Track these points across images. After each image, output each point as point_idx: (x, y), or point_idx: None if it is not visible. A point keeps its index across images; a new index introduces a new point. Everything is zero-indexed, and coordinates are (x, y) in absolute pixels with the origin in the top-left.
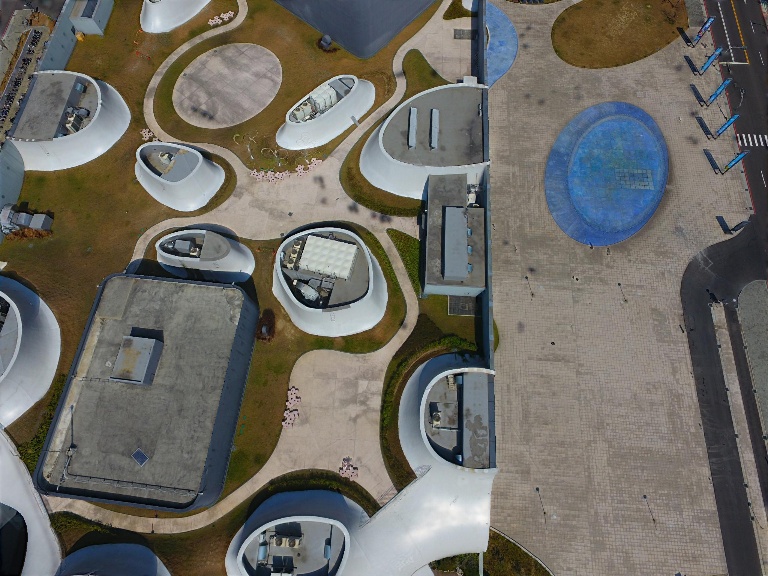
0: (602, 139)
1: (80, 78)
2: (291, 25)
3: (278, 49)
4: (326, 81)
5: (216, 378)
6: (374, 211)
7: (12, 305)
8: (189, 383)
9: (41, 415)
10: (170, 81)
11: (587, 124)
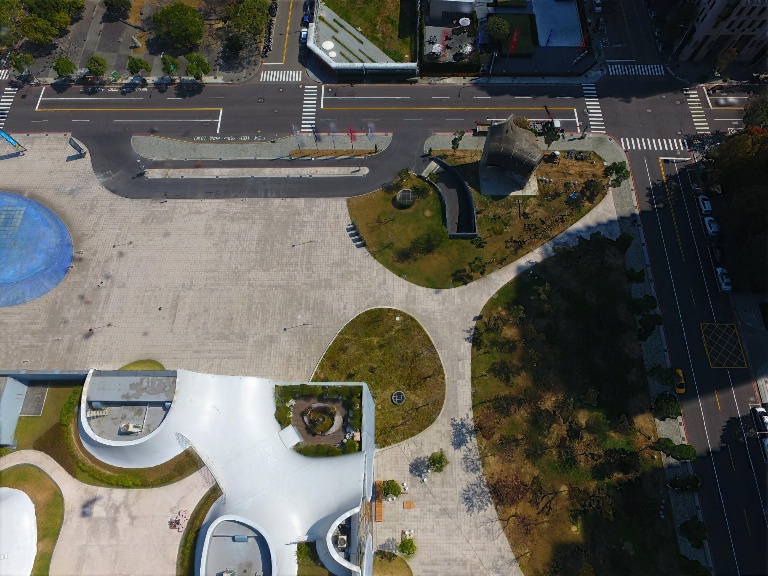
0: None
1: None
2: None
3: None
4: None
5: None
6: None
7: None
8: None
9: None
10: None
11: None
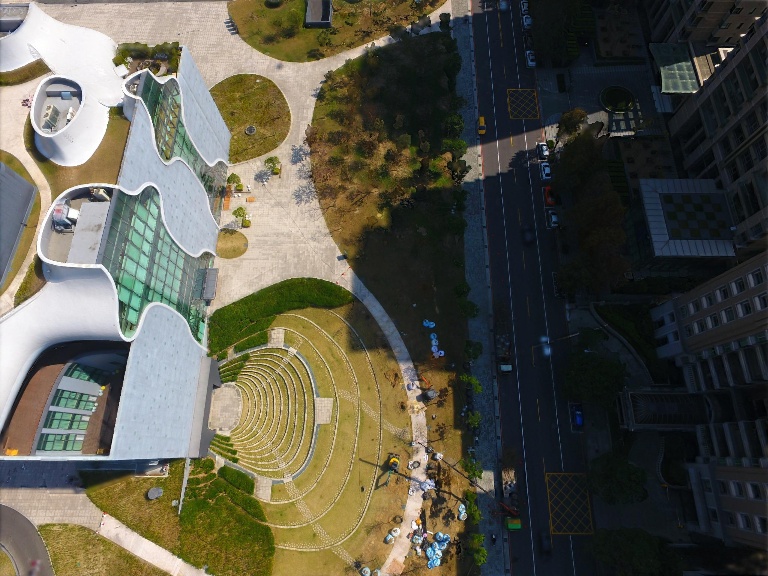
0: None
1: None
2: None
3: None
4: None
5: None
6: None
7: None
8: None
9: None
10: None
11: None
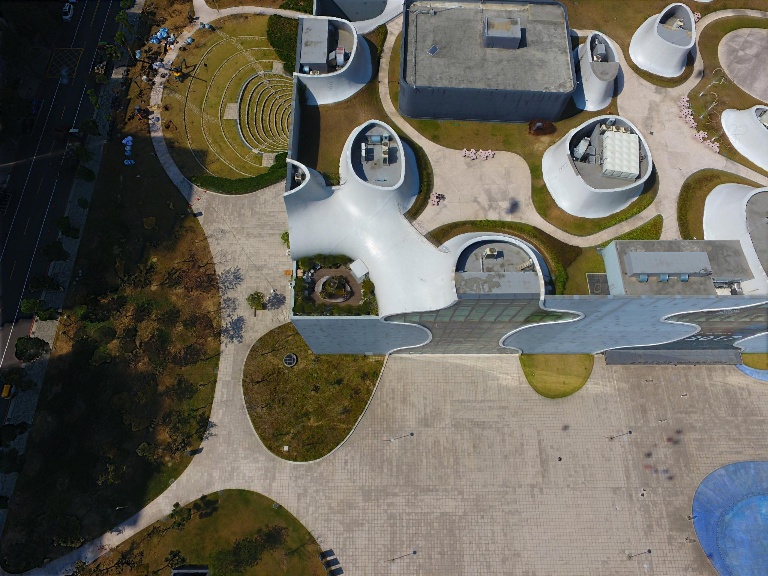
0: None
1: None
2: None
3: None
4: None
5: (497, 85)
6: (677, 202)
7: None
8: (490, 69)
9: None
10: (759, 24)
11: None
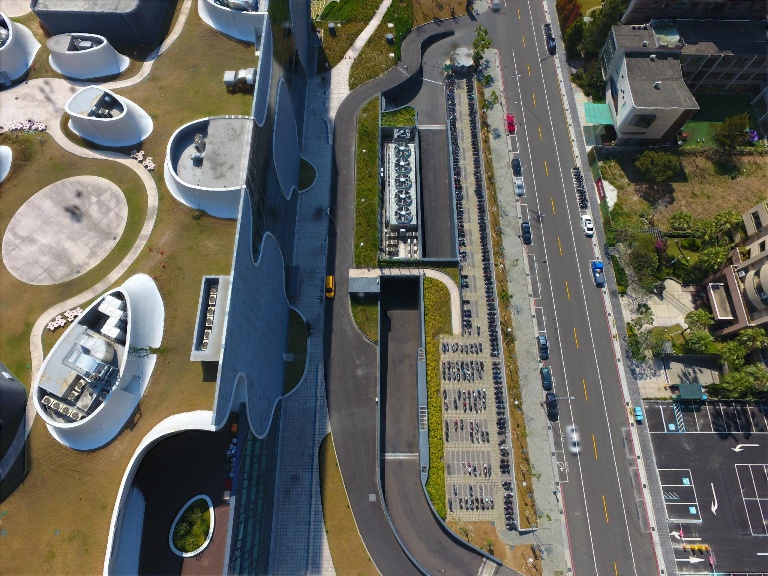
0: None
1: None
2: None
3: (2, 277)
4: None
5: None
6: None
7: (211, 1)
8: None
9: None
10: (131, 229)
11: None
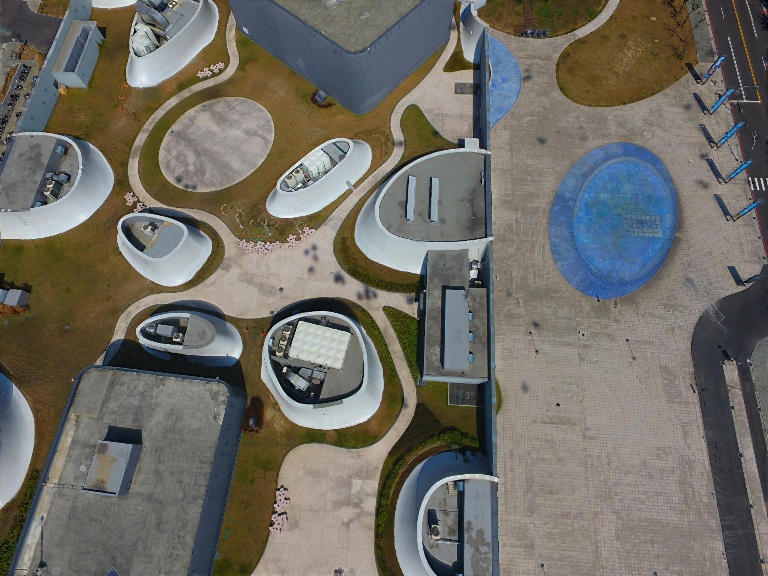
0: (609, 183)
1: (61, 140)
2: (284, 77)
3: (270, 104)
4: (319, 145)
5: (198, 486)
6: (370, 286)
7: None
8: (169, 491)
9: (12, 517)
10: (156, 139)
11: (593, 166)
